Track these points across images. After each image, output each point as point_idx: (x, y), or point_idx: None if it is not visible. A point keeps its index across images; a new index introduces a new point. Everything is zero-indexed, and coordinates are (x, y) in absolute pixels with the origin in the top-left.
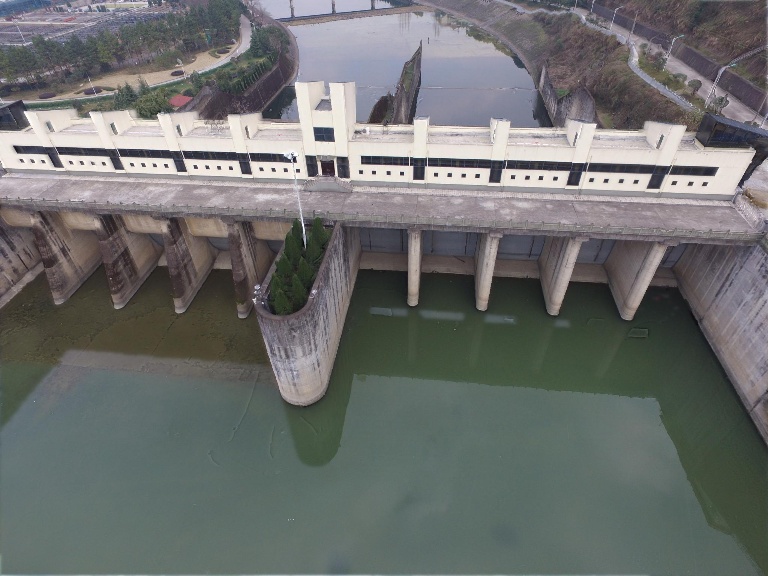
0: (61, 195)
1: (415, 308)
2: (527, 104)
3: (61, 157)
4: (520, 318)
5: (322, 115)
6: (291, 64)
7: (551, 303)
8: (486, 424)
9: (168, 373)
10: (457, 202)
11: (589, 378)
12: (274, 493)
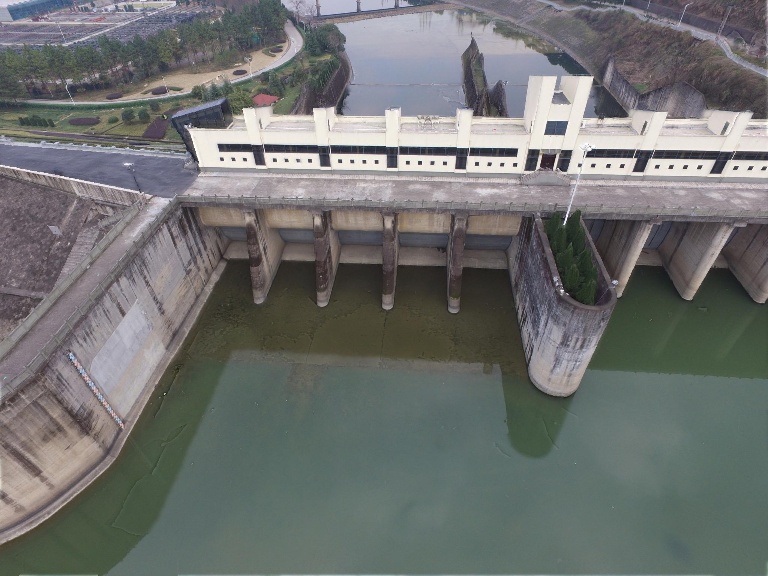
0: (275, 193)
1: (619, 299)
2: (589, 100)
3: (266, 155)
4: (715, 307)
5: (560, 109)
6: (345, 62)
7: (762, 291)
8: (749, 409)
9: (409, 369)
10: (682, 193)
11: None
12: (578, 482)
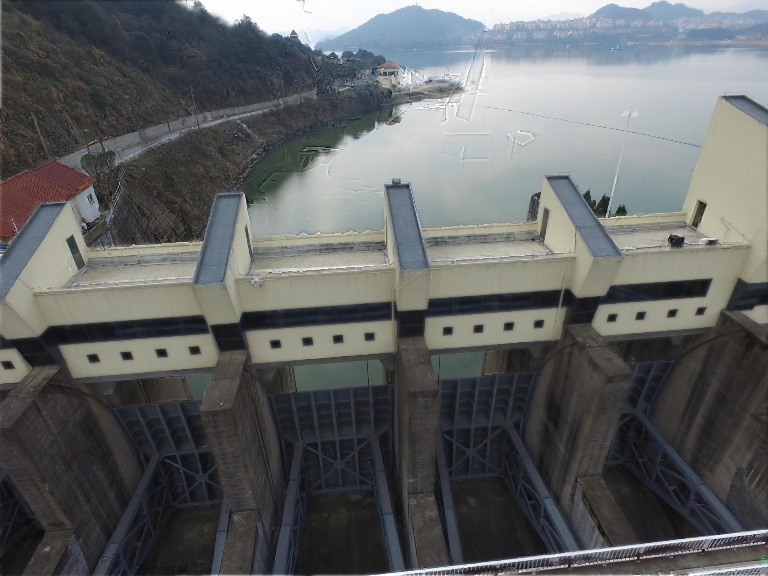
0: None
1: None
2: None
3: None
4: None
5: None
6: None
7: None
8: None
9: None
10: None
11: None
12: None
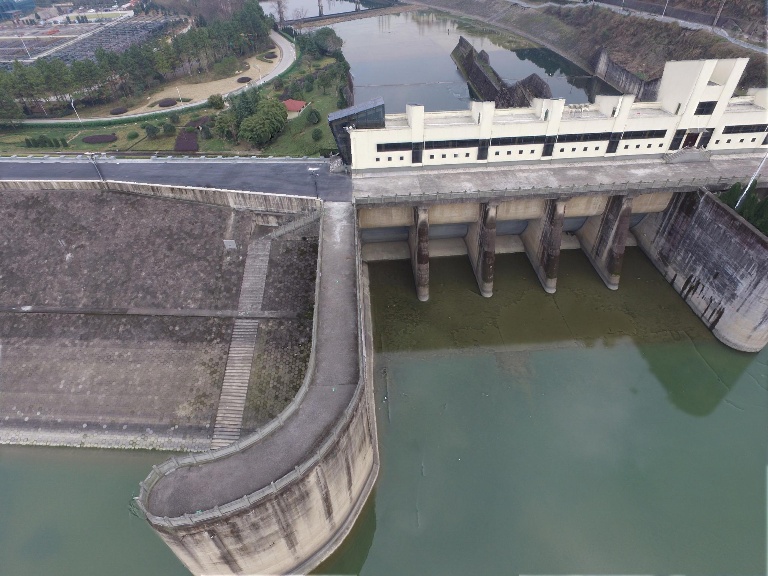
0: (444, 188)
1: None
2: (583, 90)
3: (424, 152)
4: None
5: (713, 90)
6: None
7: None
8: None
9: (606, 344)
10: None
11: None
12: None
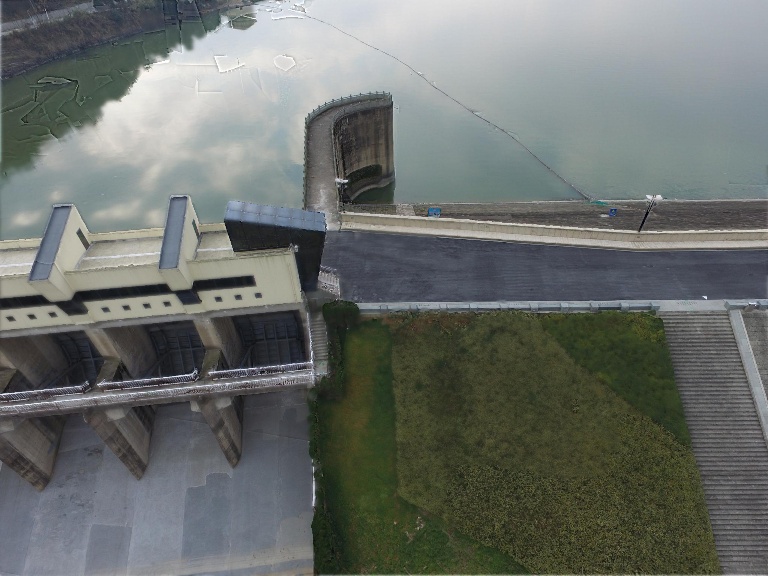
0: None
1: None
2: None
3: None
4: None
5: None
6: None
7: None
8: None
9: None
10: None
11: None
12: (34, 234)
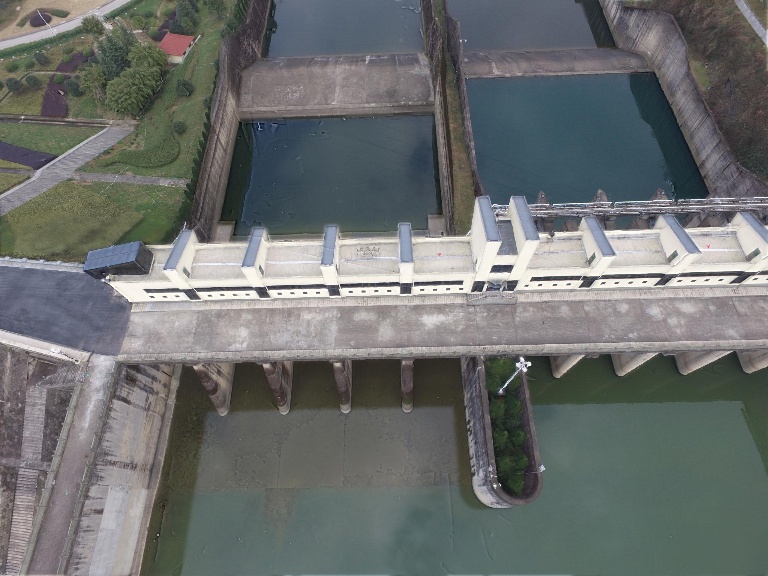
0: (217, 338)
1: None
2: None
3: (199, 293)
4: None
5: (505, 258)
6: None
7: (687, 368)
8: (650, 502)
9: (369, 486)
10: (624, 310)
11: (690, 394)
12: None
